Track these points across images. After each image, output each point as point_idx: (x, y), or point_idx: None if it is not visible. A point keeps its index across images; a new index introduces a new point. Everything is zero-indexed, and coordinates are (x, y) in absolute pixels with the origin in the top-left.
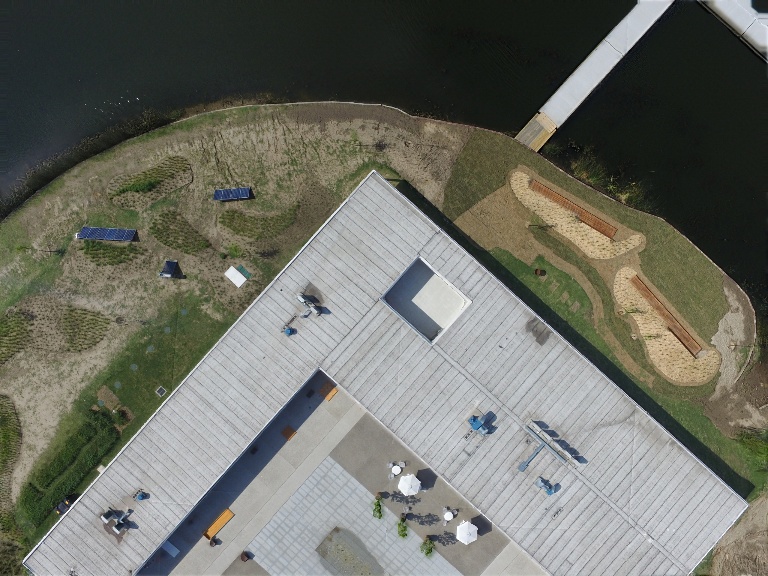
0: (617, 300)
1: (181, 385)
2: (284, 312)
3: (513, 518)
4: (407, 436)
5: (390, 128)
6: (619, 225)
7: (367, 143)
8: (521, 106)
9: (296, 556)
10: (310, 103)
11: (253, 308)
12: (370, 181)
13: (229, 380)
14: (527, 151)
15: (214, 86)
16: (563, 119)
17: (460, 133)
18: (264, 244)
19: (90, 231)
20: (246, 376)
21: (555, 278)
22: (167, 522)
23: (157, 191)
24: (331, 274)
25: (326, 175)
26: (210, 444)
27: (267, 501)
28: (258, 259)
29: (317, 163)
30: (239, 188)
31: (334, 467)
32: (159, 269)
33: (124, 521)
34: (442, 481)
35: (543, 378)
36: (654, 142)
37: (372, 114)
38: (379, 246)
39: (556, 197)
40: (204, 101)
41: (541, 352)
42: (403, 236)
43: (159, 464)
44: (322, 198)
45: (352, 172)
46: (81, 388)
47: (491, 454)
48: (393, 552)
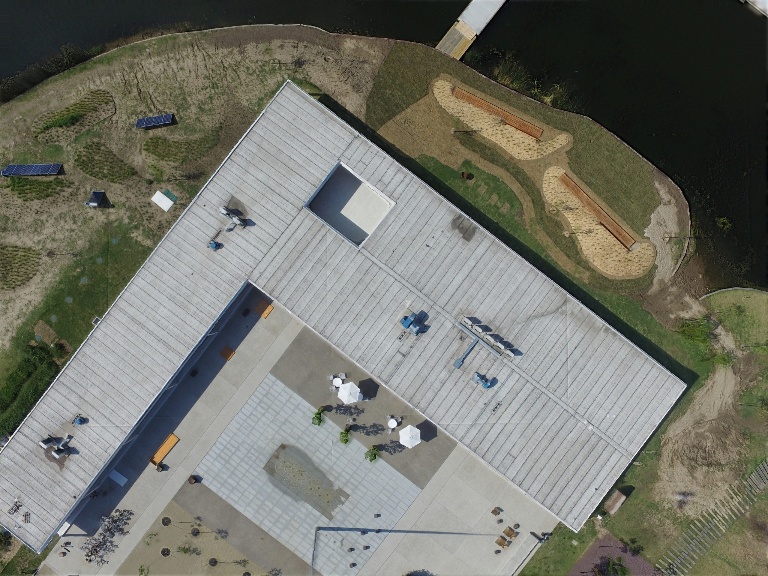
0: (547, 199)
1: (111, 307)
2: (209, 227)
3: (452, 415)
4: (340, 341)
5: (309, 46)
6: (545, 126)
7: (286, 61)
8: (440, 15)
9: (244, 476)
10: (229, 28)
11: (178, 225)
12: (285, 91)
13: (159, 299)
14: (449, 60)
15: (132, 19)
16: (482, 25)
17: (380, 47)
18: (189, 167)
19: (15, 168)
20: (175, 294)
21: (483, 181)
22: (107, 445)
23: (80, 124)
24: (253, 186)
25: (247, 95)
26: (145, 364)
27: (211, 423)
28: (184, 182)
29: (238, 84)
30: (162, 115)
31: (275, 384)
32: (87, 200)
33: (64, 447)
34: (384, 390)
35: (472, 274)
36: (576, 43)
37: (291, 34)
38: (299, 155)
39: (480, 102)
40: (124, 35)
41: (468, 248)
42: (322, 143)
43: (95, 388)
44: (244, 118)
45: (272, 90)
46: (17, 325)
47: (426, 353)
48: (340, 465)
